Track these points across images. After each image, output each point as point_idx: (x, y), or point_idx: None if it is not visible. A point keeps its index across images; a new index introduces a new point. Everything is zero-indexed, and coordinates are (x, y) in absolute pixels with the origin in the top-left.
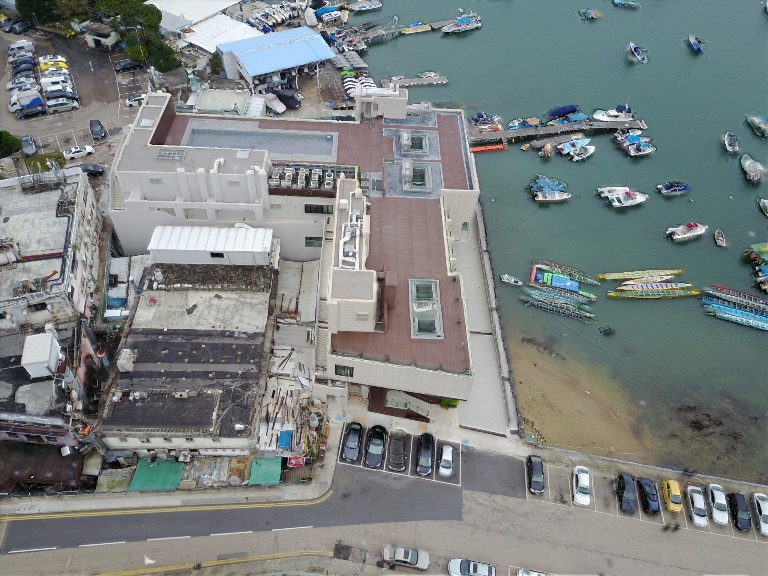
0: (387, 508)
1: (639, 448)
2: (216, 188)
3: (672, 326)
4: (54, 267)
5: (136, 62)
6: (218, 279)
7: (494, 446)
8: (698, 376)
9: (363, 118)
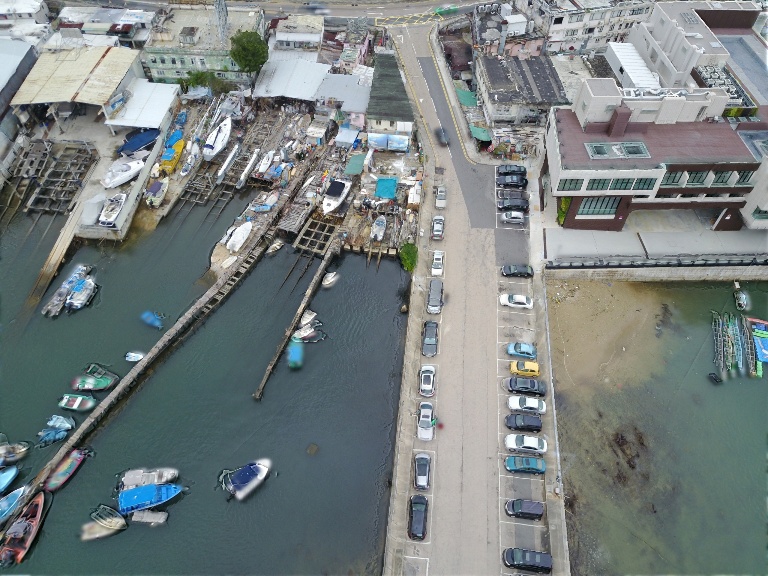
0: (471, 190)
1: (575, 379)
2: (676, 47)
3: (760, 455)
4: (570, 8)
5: None
6: None
7: (534, 250)
8: (693, 465)
9: None
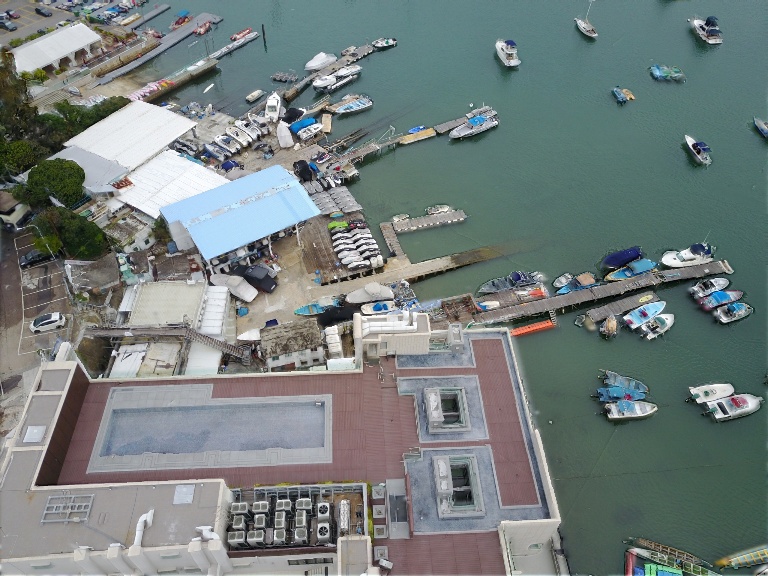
0: None
1: None
2: (142, 564)
3: None
4: None
5: (48, 252)
6: None
7: None
8: None
9: (366, 359)
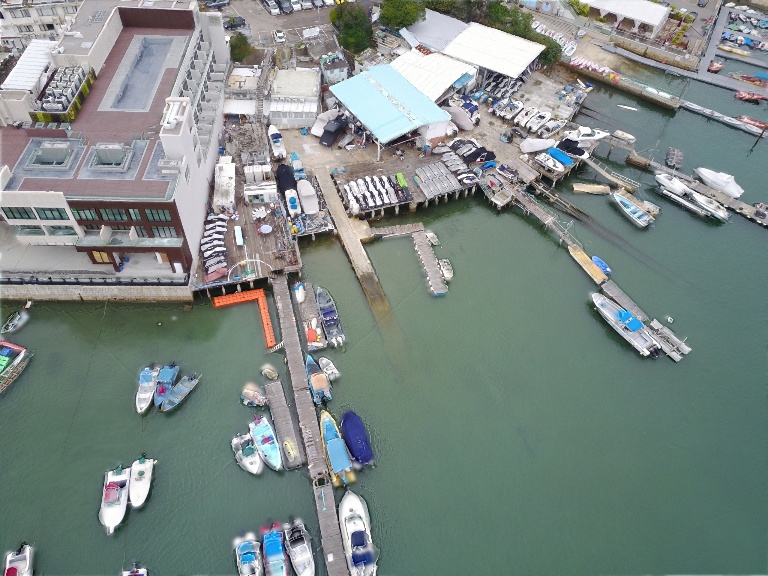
0: None
1: None
2: None
3: None
4: (14, 3)
5: None
6: (4, 79)
7: None
8: None
9: None
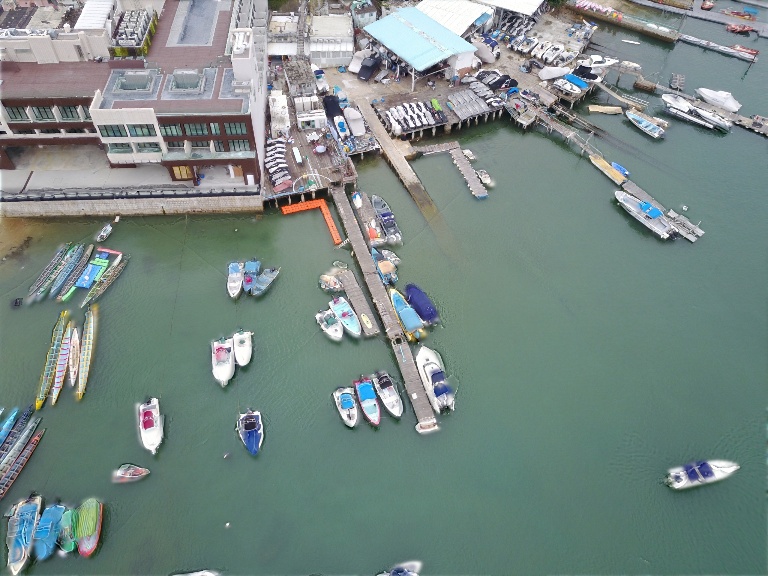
0: None
1: None
2: None
3: (3, 370)
4: None
5: None
6: None
7: None
8: None
9: None
